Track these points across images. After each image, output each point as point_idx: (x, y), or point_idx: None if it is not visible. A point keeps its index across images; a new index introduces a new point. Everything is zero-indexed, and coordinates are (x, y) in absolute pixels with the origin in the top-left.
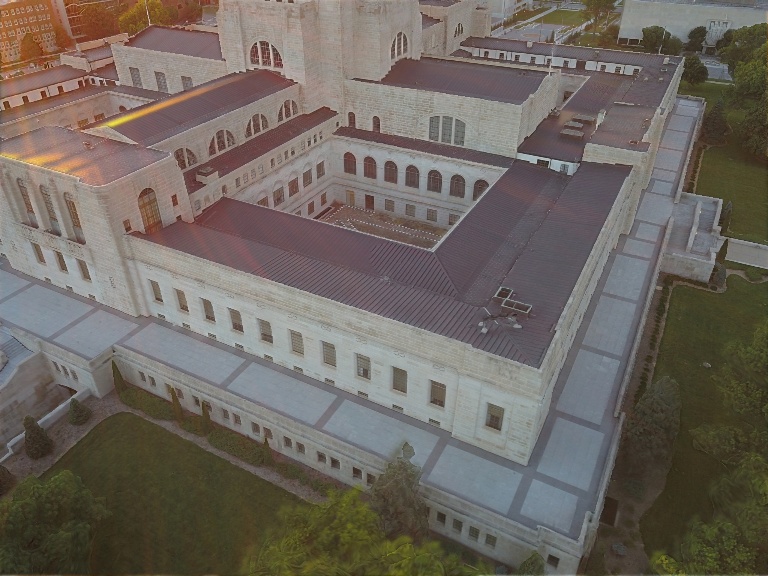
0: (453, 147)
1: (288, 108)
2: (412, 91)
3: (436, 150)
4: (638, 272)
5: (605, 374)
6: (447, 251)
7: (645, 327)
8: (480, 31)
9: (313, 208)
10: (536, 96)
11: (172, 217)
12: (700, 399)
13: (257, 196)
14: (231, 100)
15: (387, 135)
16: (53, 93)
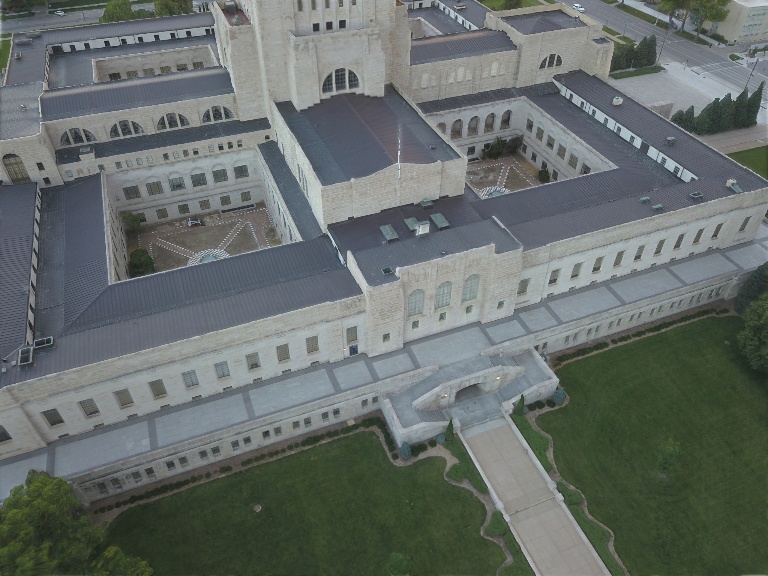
0: (305, 198)
1: (220, 112)
2: (288, 133)
3: (292, 195)
4: (306, 394)
5: (124, 450)
6: (120, 289)
7: (272, 444)
8: (590, 67)
9: (230, 201)
10: (361, 181)
11: (38, 177)
12: (200, 525)
13: (146, 179)
14: (158, 96)
15: (286, 163)
16: (182, 36)
